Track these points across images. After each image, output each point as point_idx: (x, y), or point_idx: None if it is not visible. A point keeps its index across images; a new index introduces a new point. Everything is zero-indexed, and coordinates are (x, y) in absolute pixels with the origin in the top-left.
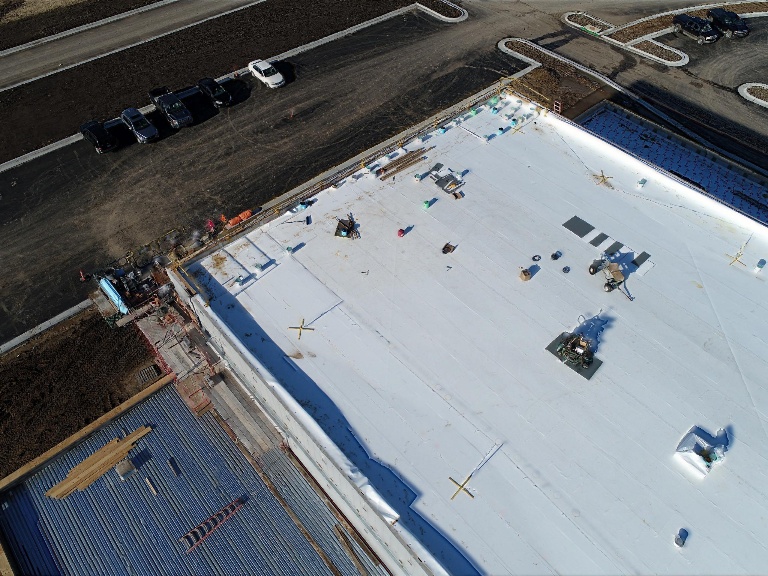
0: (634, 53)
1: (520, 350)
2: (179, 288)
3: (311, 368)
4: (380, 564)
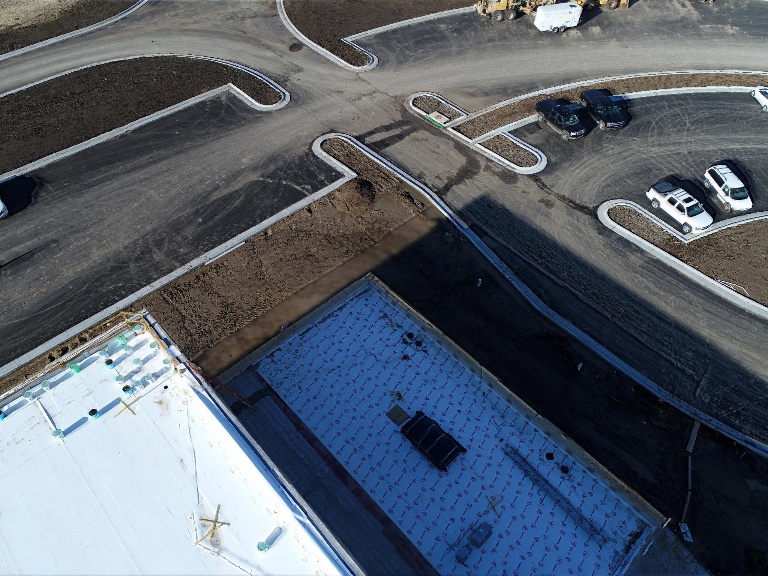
0: (481, 154)
1: None
2: None
3: None
4: None
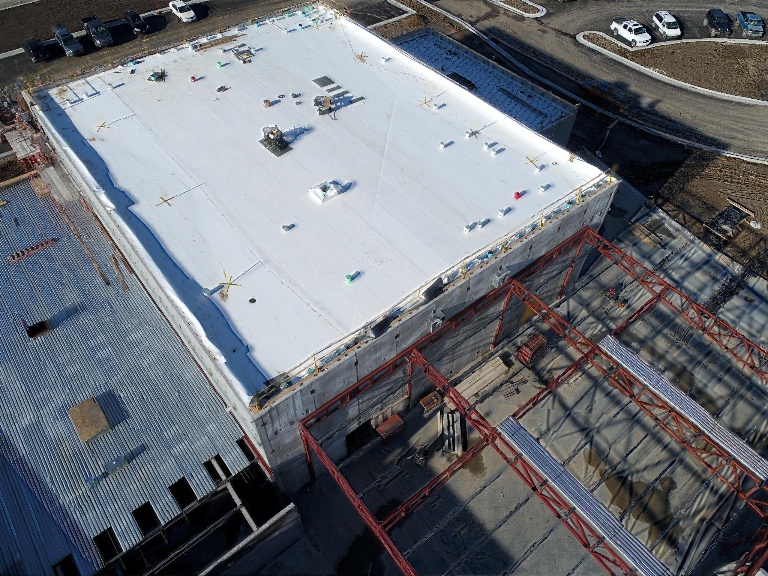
0: (501, 7)
1: (241, 141)
2: (27, 103)
3: (98, 145)
4: (133, 273)
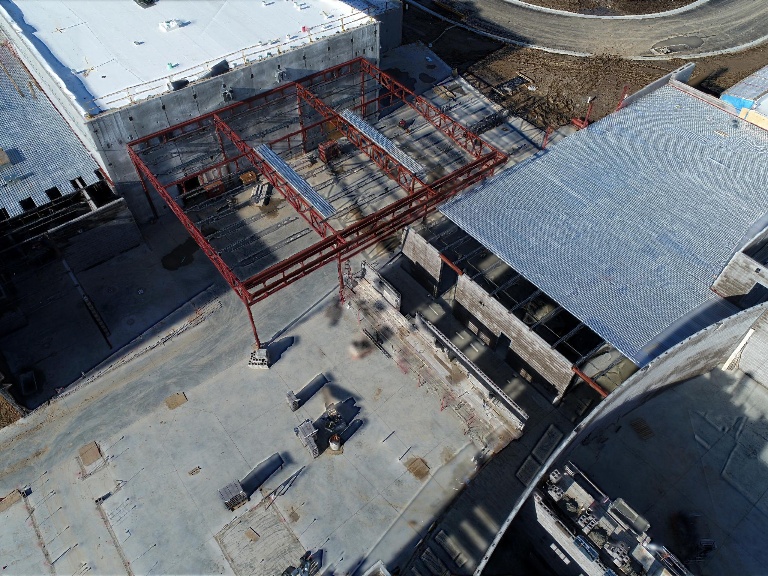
0: None
1: (121, 1)
2: None
3: (19, 3)
4: (42, 91)
